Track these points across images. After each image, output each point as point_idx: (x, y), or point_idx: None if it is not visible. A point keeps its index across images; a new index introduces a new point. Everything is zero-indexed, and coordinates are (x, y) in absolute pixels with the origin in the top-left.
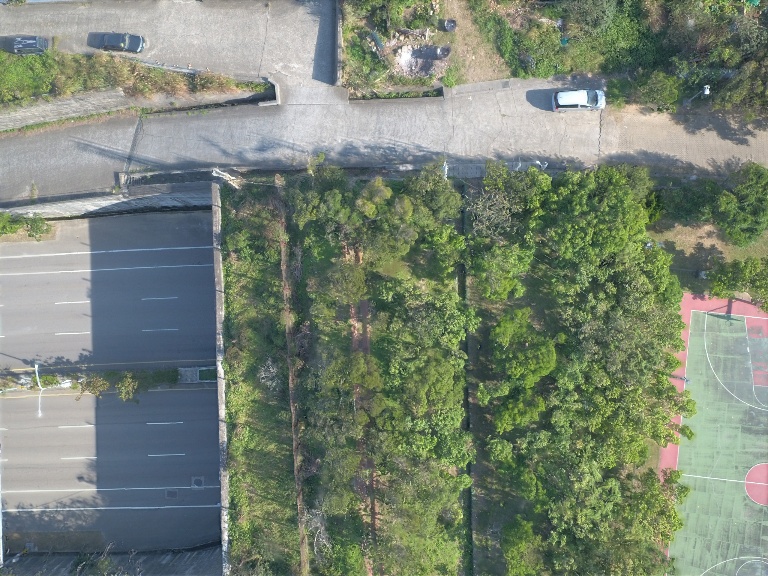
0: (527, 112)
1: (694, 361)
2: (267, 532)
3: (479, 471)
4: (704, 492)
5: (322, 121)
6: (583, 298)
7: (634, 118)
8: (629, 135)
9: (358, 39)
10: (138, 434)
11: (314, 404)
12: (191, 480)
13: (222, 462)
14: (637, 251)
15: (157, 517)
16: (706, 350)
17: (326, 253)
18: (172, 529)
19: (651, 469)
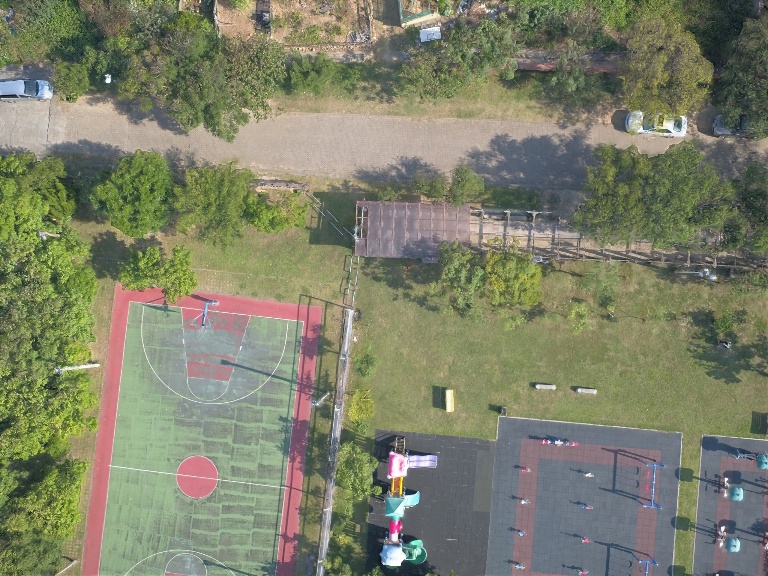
0: None
1: (131, 352)
2: None
3: None
4: (136, 484)
5: None
6: None
7: (80, 108)
8: (75, 125)
9: None
10: None
11: None
12: None
13: None
14: (27, 241)
15: None
16: (142, 341)
17: None
18: None
19: (68, 460)
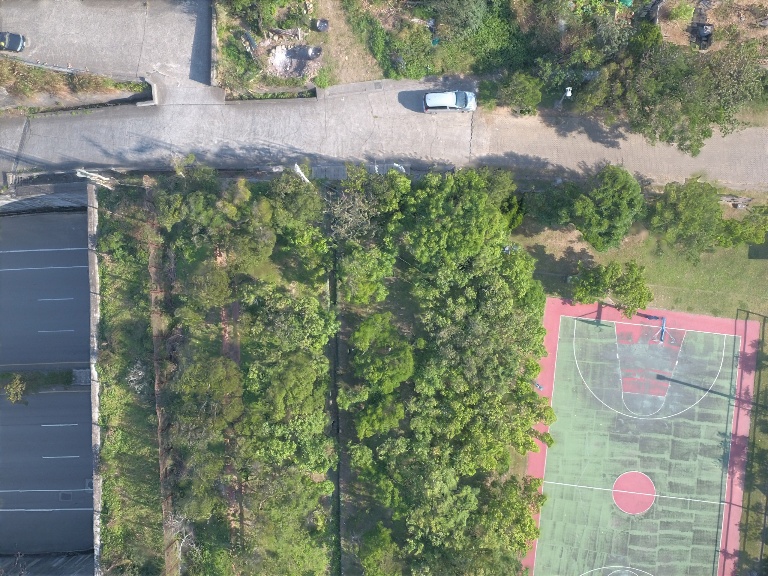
0: (399, 113)
1: (563, 367)
2: (139, 537)
3: (347, 477)
4: (571, 500)
5: (199, 122)
6: (443, 303)
7: (505, 120)
8: (500, 137)
9: (233, 39)
10: (33, 436)
11: (179, 408)
12: (85, 482)
13: (95, 466)
14: (494, 255)
15: (51, 519)
16: (575, 356)
17: (198, 255)
18: (66, 532)
19: (514, 477)
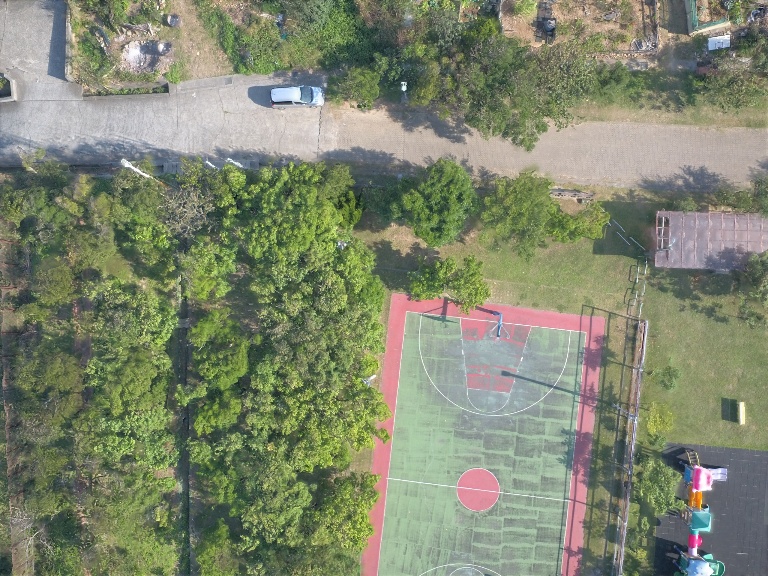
0: (248, 109)
1: (408, 363)
2: None
3: None
4: (415, 497)
5: (57, 118)
6: (279, 298)
7: (352, 115)
8: (347, 133)
9: (89, 34)
10: None
11: (25, 404)
12: None
13: None
14: (326, 251)
15: None
16: (420, 352)
17: (51, 251)
18: None
19: (353, 473)
